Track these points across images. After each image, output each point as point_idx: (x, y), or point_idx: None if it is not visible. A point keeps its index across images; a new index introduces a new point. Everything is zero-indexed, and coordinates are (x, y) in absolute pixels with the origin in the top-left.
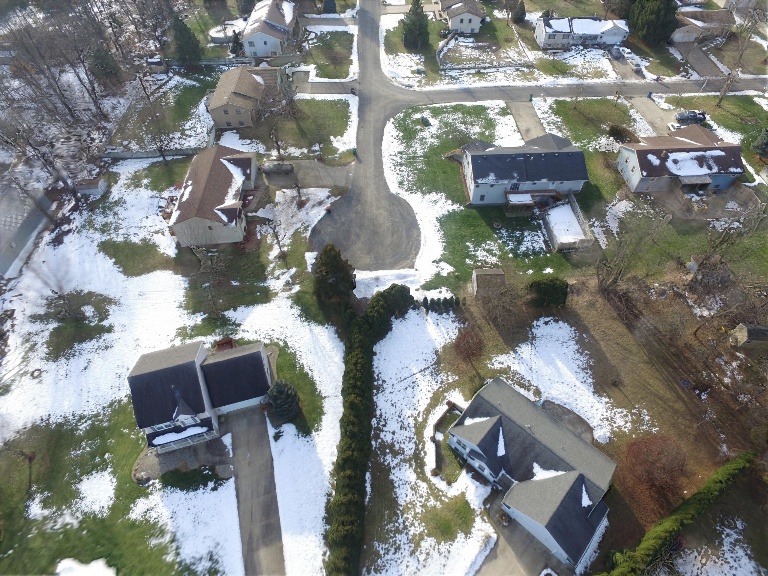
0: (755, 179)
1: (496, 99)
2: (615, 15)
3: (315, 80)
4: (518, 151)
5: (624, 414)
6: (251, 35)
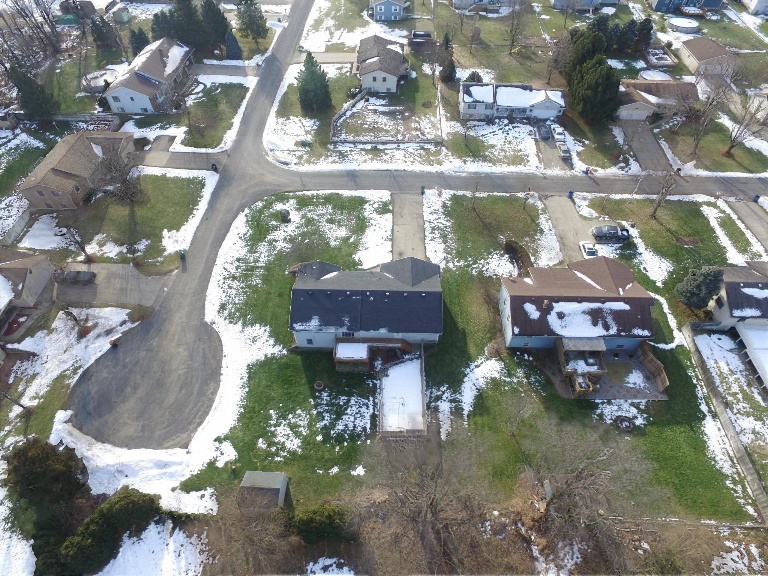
0: (674, 338)
1: (381, 188)
2: (563, 77)
3: (177, 149)
4: (359, 284)
5: None
6: (113, 90)
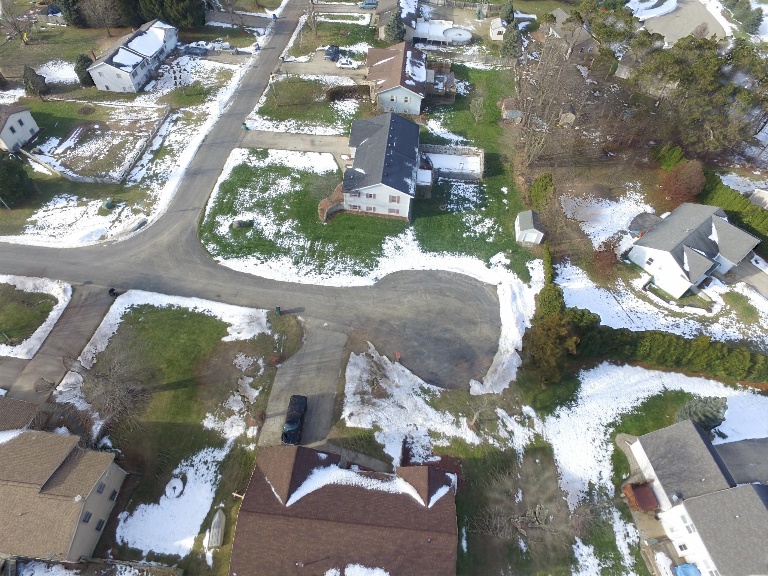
0: None
1: (228, 153)
2: None
3: (33, 347)
4: (377, 151)
5: (631, 193)
6: None
